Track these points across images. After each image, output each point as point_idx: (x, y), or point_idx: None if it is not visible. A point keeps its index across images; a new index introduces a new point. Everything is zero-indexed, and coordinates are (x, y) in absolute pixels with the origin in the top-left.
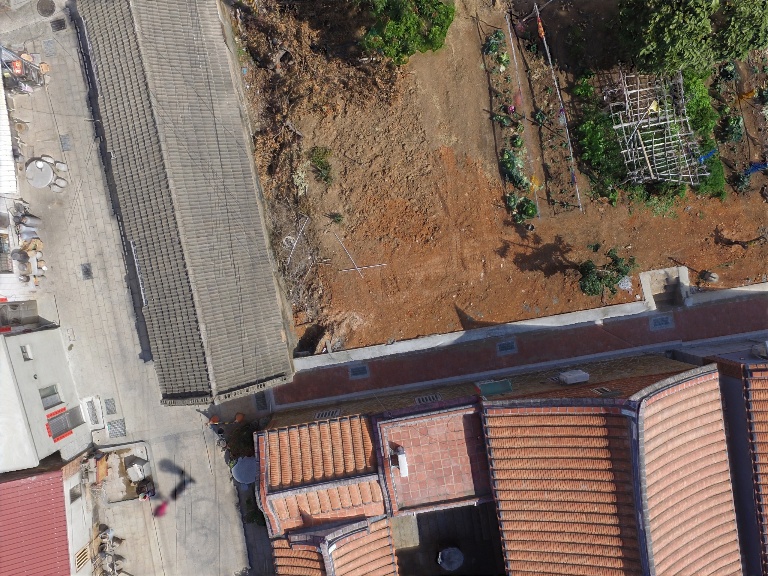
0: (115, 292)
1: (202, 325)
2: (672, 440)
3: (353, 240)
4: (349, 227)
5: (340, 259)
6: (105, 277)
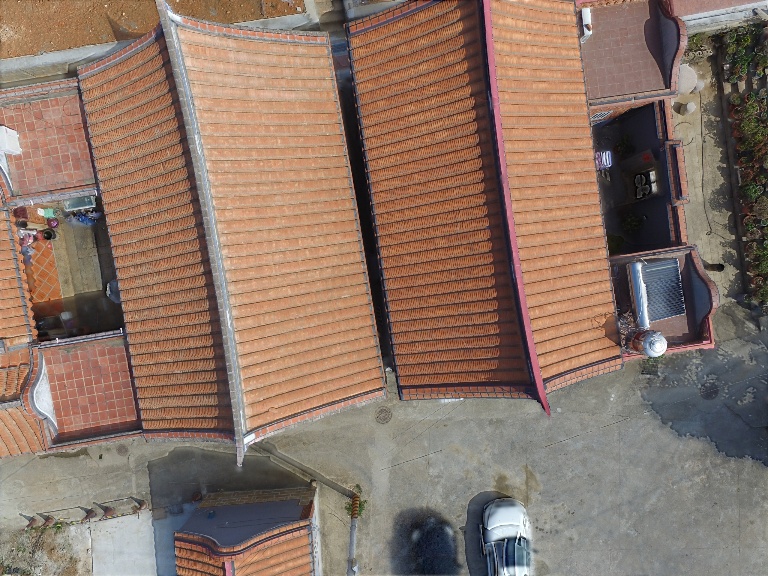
0: None
1: None
2: (257, 90)
3: None
4: None
5: None
6: None
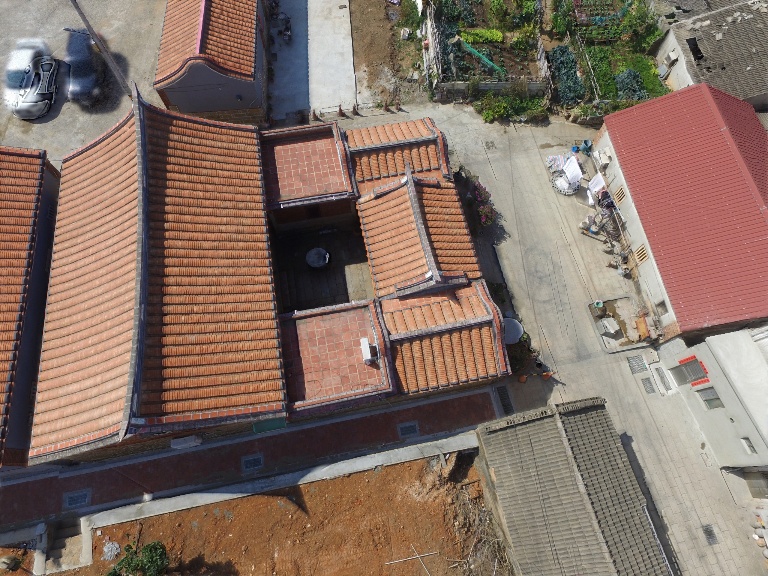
0: (674, 511)
1: (583, 491)
2: (95, 385)
3: None
4: None
5: (439, 568)
6: (689, 529)
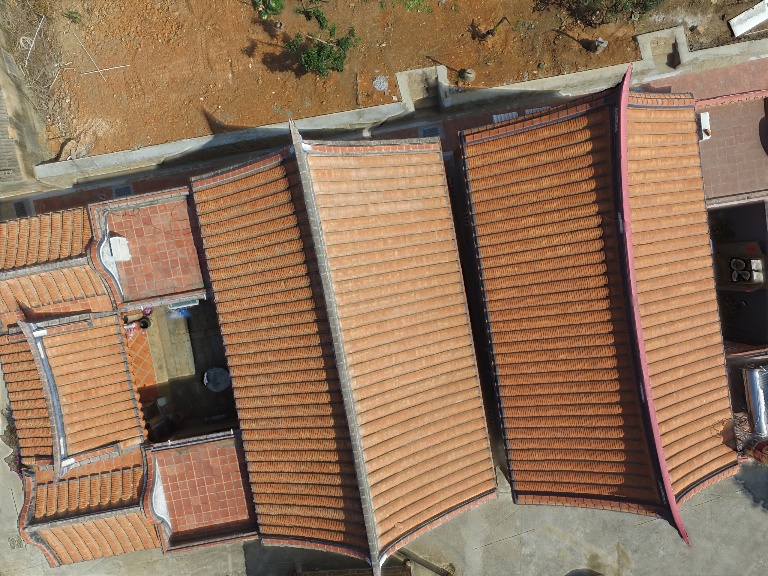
0: None
1: None
2: (376, 204)
3: (93, 40)
4: (89, 27)
5: (82, 62)
6: None
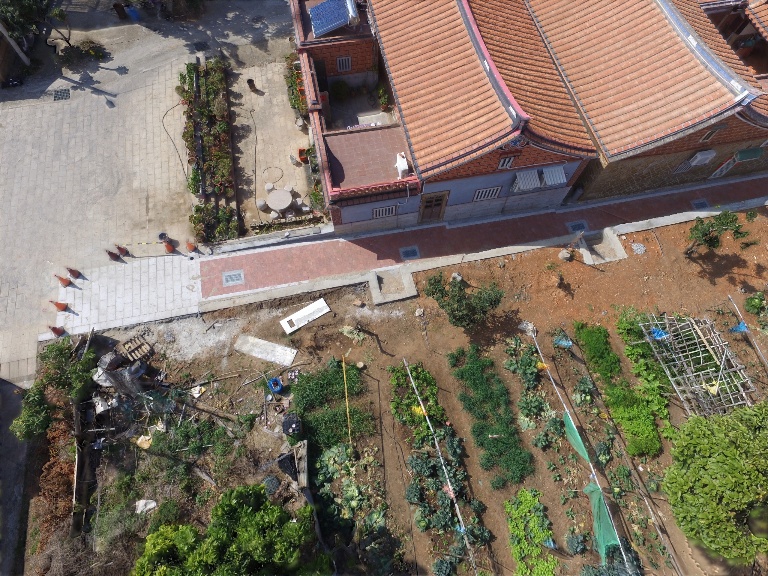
0: None
1: None
2: (657, 100)
3: None
4: None
5: None
6: None
